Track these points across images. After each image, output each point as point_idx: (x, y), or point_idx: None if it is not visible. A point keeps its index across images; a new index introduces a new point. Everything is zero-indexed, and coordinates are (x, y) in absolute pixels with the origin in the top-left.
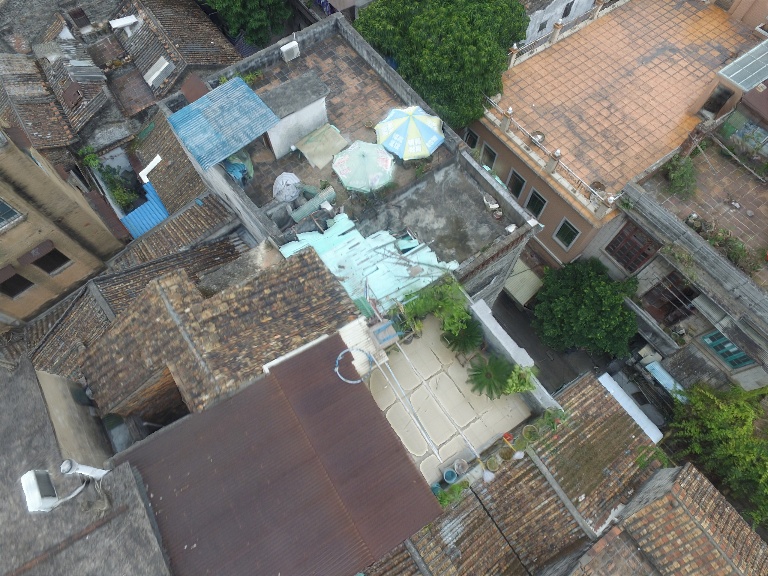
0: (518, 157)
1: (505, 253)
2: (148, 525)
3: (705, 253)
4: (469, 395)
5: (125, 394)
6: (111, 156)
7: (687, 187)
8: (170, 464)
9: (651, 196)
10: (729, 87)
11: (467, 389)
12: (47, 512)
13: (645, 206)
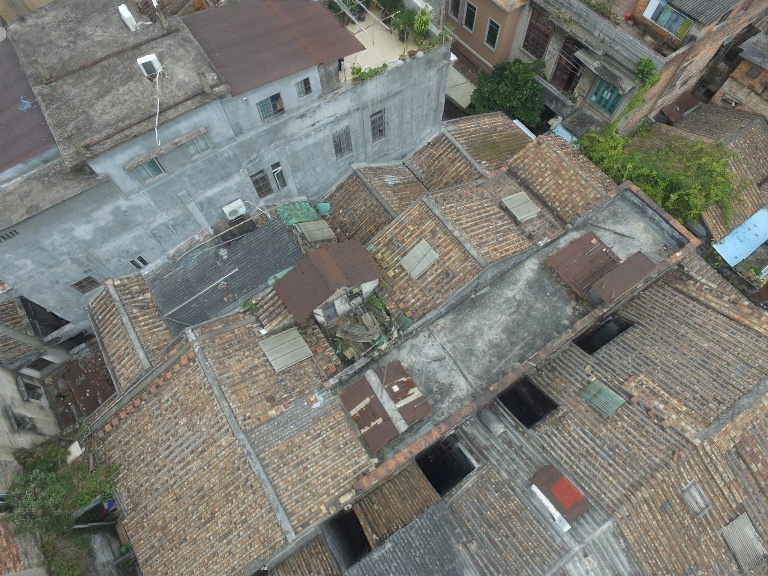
0: None
1: None
2: (192, 36)
3: (580, 11)
4: (395, 47)
5: (171, 14)
6: (136, 2)
7: None
8: (202, 25)
9: None
10: None
11: (394, 45)
12: (133, 32)
13: None
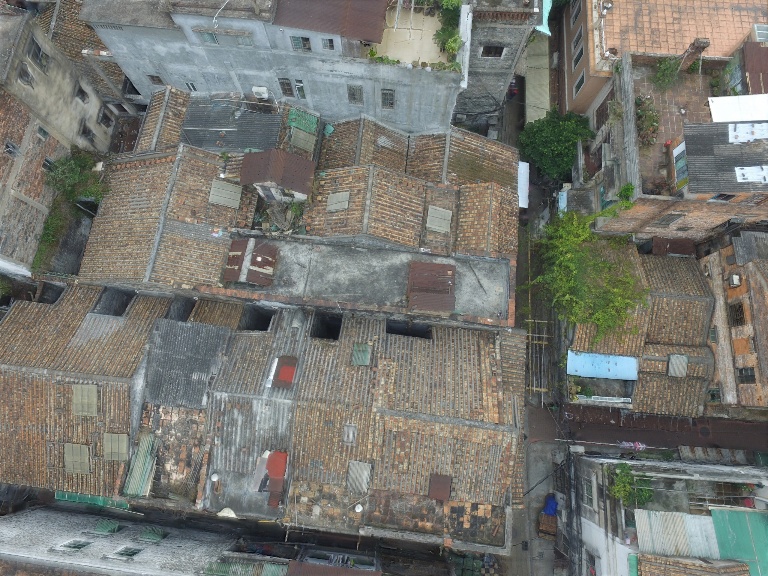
0: (586, 10)
1: (511, 21)
2: None
3: (629, 113)
4: (432, 51)
5: None
6: None
7: (662, 81)
8: None
9: (631, 65)
10: (752, 38)
11: (434, 49)
12: None
13: (624, 72)
